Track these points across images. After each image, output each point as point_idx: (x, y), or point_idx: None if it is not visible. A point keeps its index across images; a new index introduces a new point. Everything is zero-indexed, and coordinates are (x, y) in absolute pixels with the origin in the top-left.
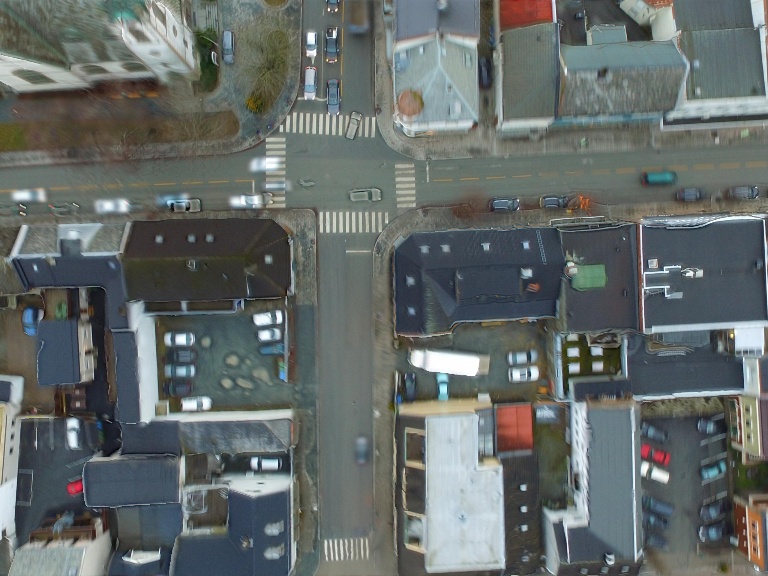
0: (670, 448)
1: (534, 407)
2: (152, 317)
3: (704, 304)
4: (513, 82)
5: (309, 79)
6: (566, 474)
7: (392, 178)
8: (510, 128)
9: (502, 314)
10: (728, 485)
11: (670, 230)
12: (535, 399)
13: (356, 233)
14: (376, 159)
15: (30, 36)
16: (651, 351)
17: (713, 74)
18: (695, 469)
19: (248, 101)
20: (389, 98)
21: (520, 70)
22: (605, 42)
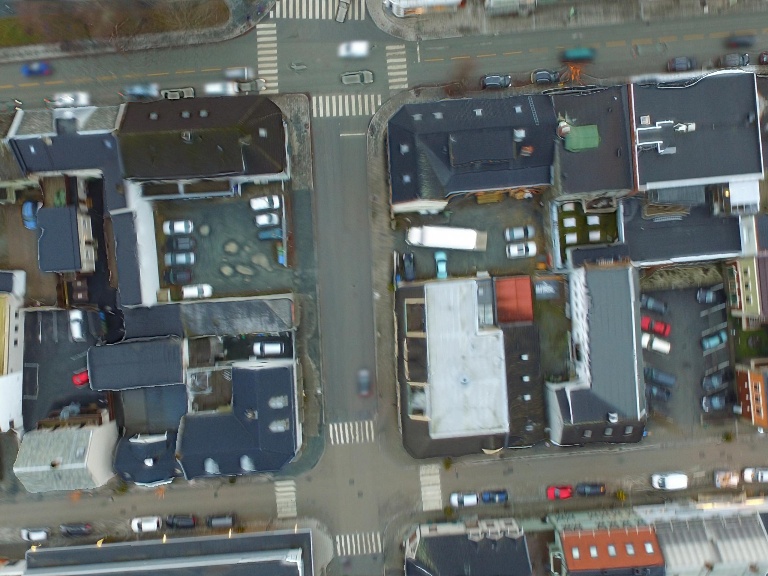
0: (670, 320)
1: (533, 282)
2: (150, 204)
3: (698, 159)
4: None
5: None
6: (567, 350)
7: (383, 60)
8: (499, 3)
9: (497, 183)
10: (729, 354)
11: (661, 89)
12: (534, 275)
13: (349, 116)
14: (367, 41)
15: None
16: (647, 216)
17: None
18: (696, 340)
19: None
20: None
21: None
22: None
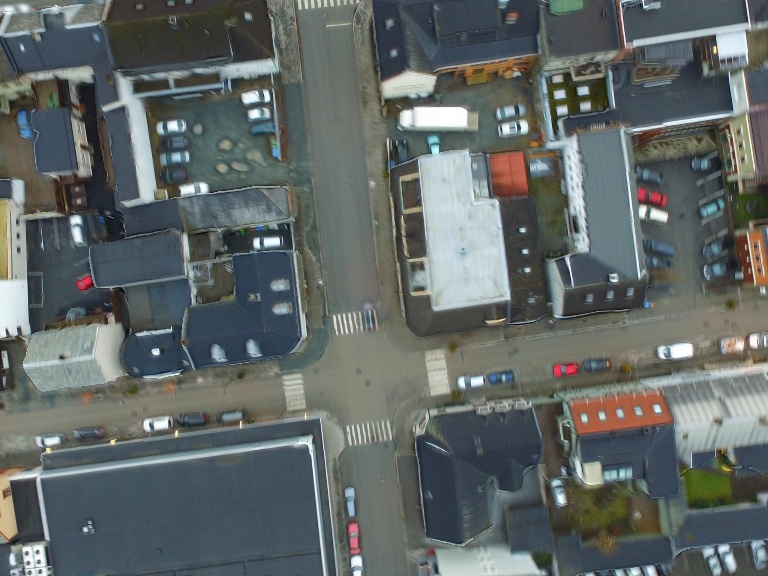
0: (666, 191)
1: (527, 160)
2: (142, 103)
3: (683, 12)
4: None
5: None
6: (565, 227)
7: None
8: None
9: (484, 56)
10: (728, 221)
11: None
12: (527, 153)
13: (334, 6)
14: None
15: None
16: (637, 81)
17: None
18: (694, 210)
19: None
20: None
21: None
22: None
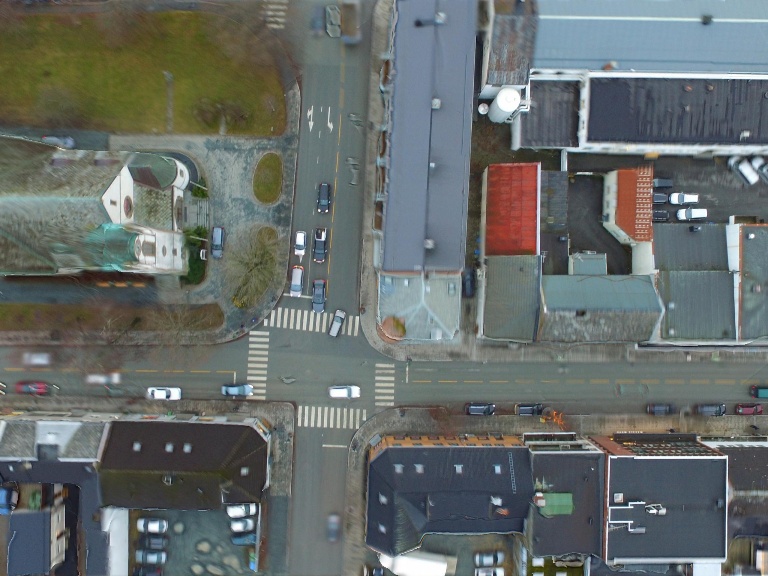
0: None
1: None
2: None
3: (665, 539)
4: (494, 309)
5: (296, 279)
6: None
7: (372, 376)
8: (490, 339)
9: (471, 528)
10: None
11: (637, 461)
12: None
13: (334, 428)
14: (357, 357)
15: (19, 249)
16: (613, 568)
17: (687, 314)
18: None
19: (234, 296)
20: (373, 300)
21: (502, 297)
22: (586, 273)
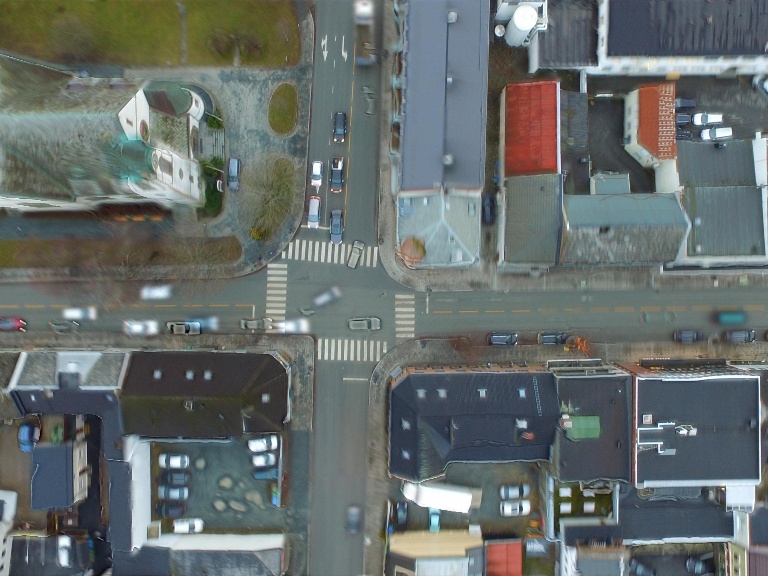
0: None
1: (524, 541)
2: None
3: (697, 461)
4: (515, 230)
5: (313, 209)
6: None
7: (392, 308)
8: (511, 266)
9: (496, 456)
10: None
11: (666, 383)
12: (526, 533)
13: (354, 361)
14: (377, 289)
15: (37, 174)
16: (643, 496)
17: (714, 231)
18: None
19: (251, 228)
20: (392, 230)
21: (523, 218)
22: (608, 192)
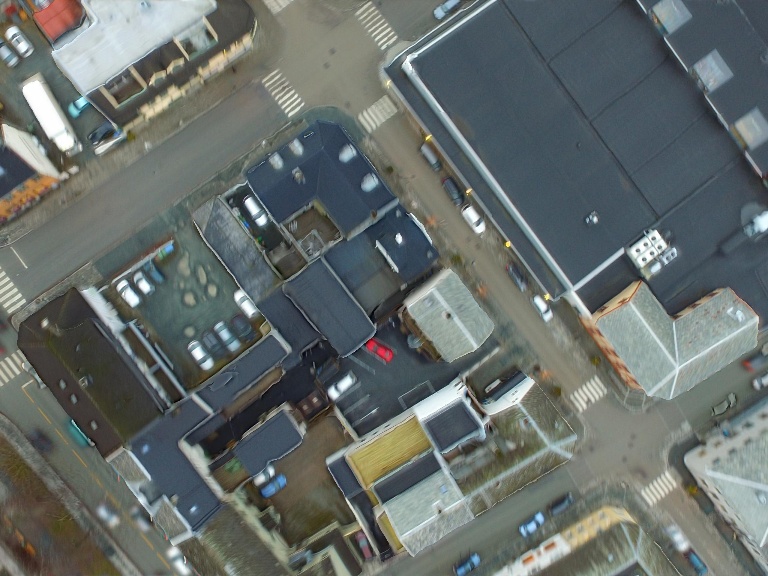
0: None
1: None
2: (191, 390)
3: None
4: None
5: None
6: None
7: None
8: None
9: None
10: None
11: None
12: None
13: (4, 271)
14: None
15: None
16: None
17: None
18: None
19: None
20: None
21: None
22: None
